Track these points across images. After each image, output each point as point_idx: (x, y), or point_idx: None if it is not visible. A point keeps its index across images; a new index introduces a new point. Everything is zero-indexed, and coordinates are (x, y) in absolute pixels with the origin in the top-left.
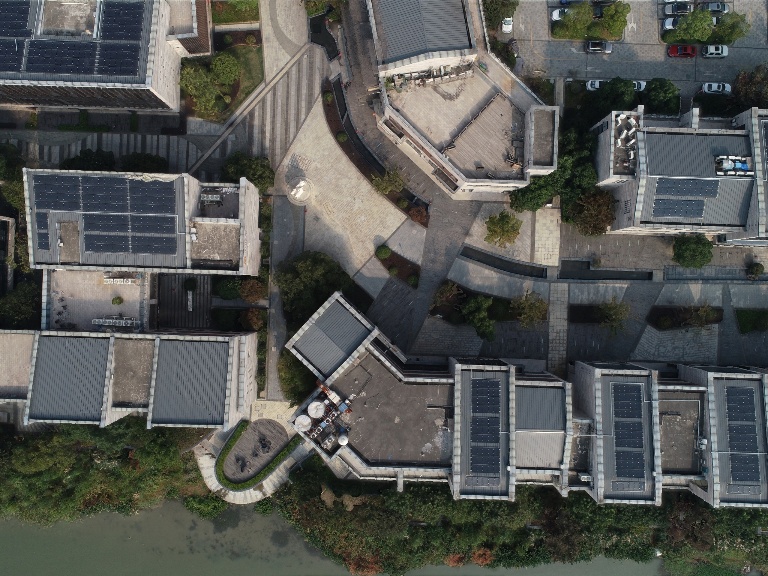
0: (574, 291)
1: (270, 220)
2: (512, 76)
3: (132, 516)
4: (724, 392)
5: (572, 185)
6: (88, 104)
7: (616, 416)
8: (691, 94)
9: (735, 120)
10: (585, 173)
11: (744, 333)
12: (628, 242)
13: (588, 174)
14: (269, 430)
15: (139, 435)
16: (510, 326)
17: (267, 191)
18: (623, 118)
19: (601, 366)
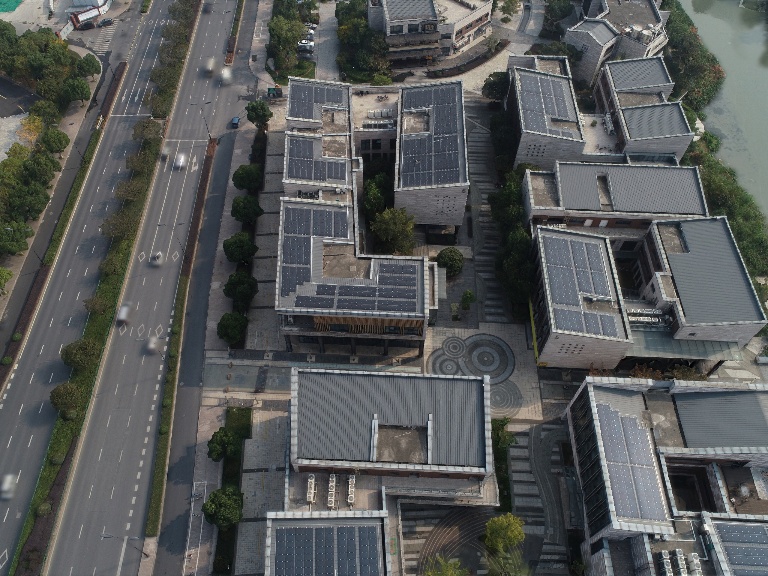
0: None
1: None
2: None
3: None
4: None
5: None
6: None
7: None
8: None
9: None
10: None
11: None
12: None
13: None
14: None
15: None
16: None
17: None
18: None
19: None
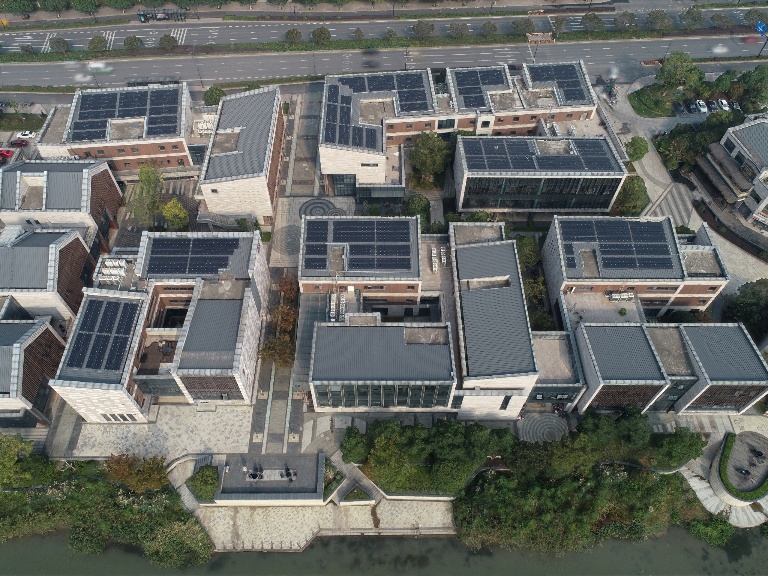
0: None
1: None
2: None
3: (640, 545)
4: None
5: None
6: (549, 206)
7: None
8: None
9: None
10: None
11: None
12: None
13: None
14: (755, 441)
15: (636, 449)
16: None
17: None
18: None
19: None
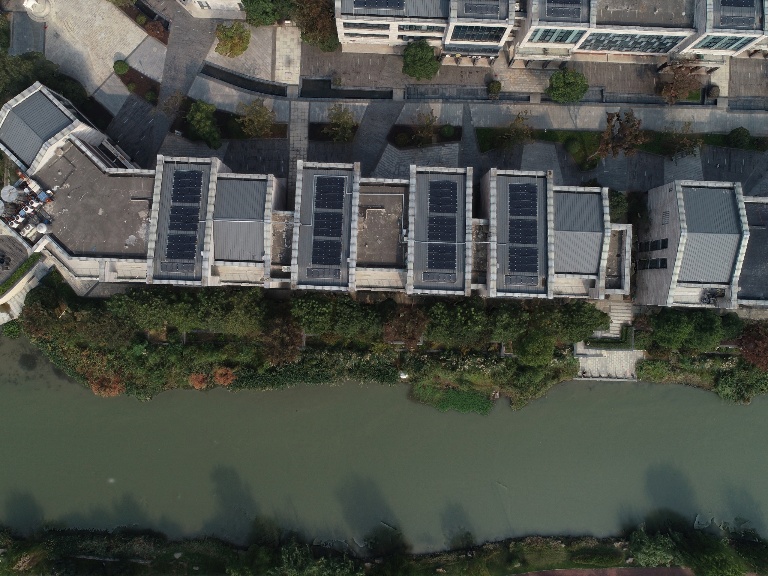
0: (314, 109)
1: (9, 35)
2: None
3: None
4: (427, 185)
5: None
6: None
7: (317, 207)
8: None
9: None
10: None
11: (483, 152)
12: (369, 61)
13: None
14: (9, 247)
15: None
16: (250, 144)
17: (7, 7)
18: None
19: None
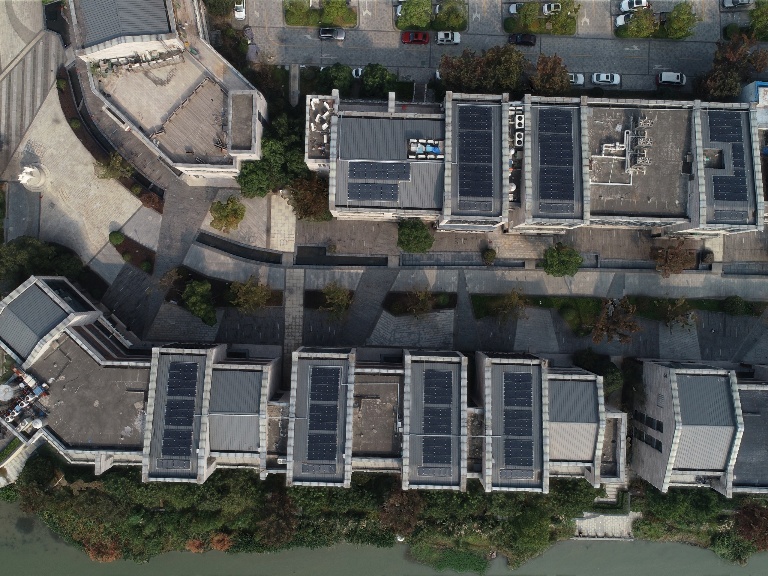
0: (310, 277)
1: (4, 206)
2: (224, 61)
3: None
4: (422, 375)
5: (287, 170)
6: None
7: (312, 399)
8: (426, 81)
9: (442, 105)
10: (292, 158)
11: (478, 318)
12: (363, 228)
13: (295, 159)
14: None
15: None
16: None
17: (2, 177)
18: (318, 102)
19: (314, 350)
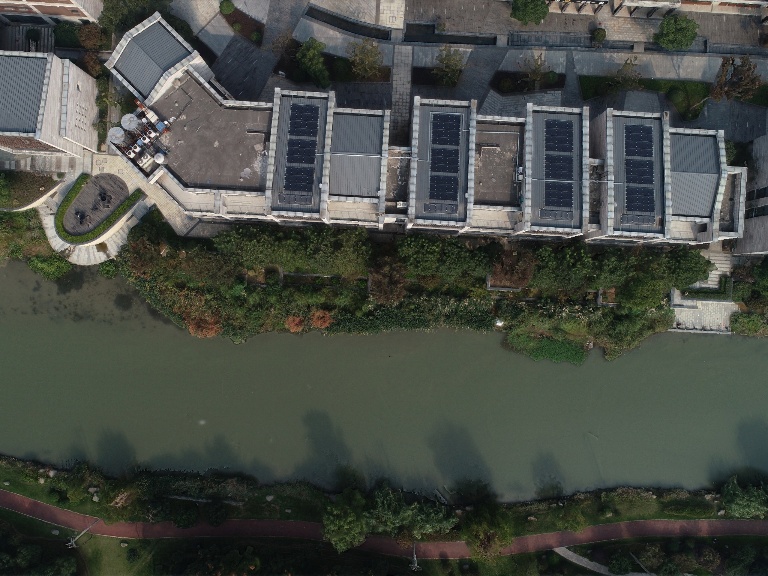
0: (418, 54)
1: None
2: None
3: None
4: (543, 124)
5: None
6: None
7: (433, 143)
8: None
9: None
10: None
11: (586, 99)
12: (473, 6)
13: None
14: (110, 185)
15: None
16: (353, 87)
17: None
18: None
19: None
